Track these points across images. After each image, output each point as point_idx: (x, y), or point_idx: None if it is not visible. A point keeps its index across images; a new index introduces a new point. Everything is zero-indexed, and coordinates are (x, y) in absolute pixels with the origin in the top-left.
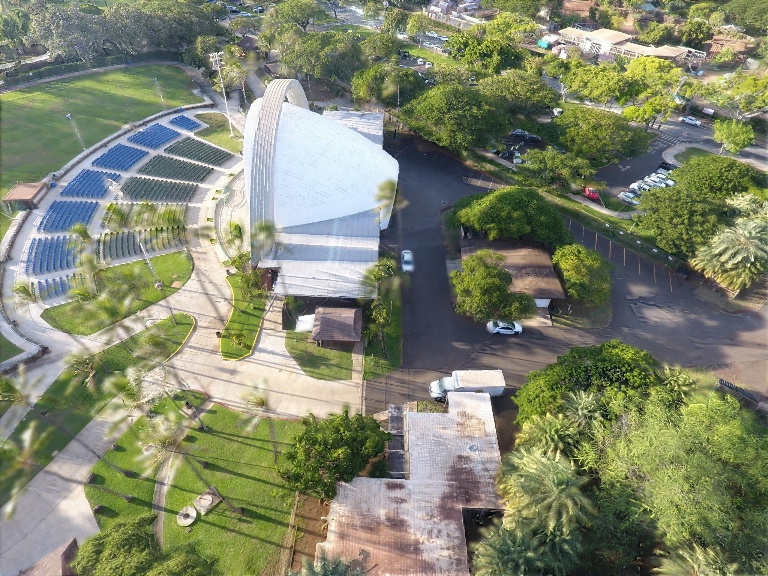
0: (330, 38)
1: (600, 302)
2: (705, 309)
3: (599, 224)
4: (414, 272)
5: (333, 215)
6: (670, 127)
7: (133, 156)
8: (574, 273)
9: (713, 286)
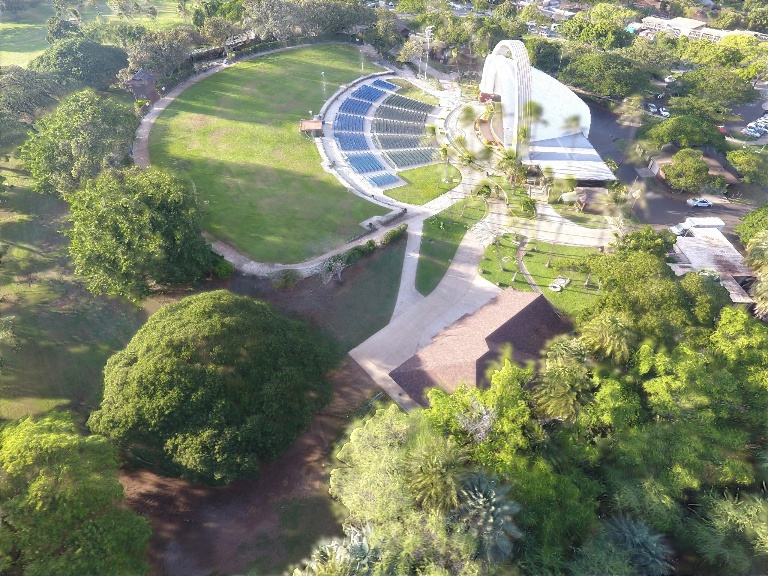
0: (481, 21)
1: (765, 185)
2: None
3: (736, 147)
4: (617, 175)
5: (555, 135)
6: (760, 89)
7: (363, 106)
8: (746, 166)
9: None
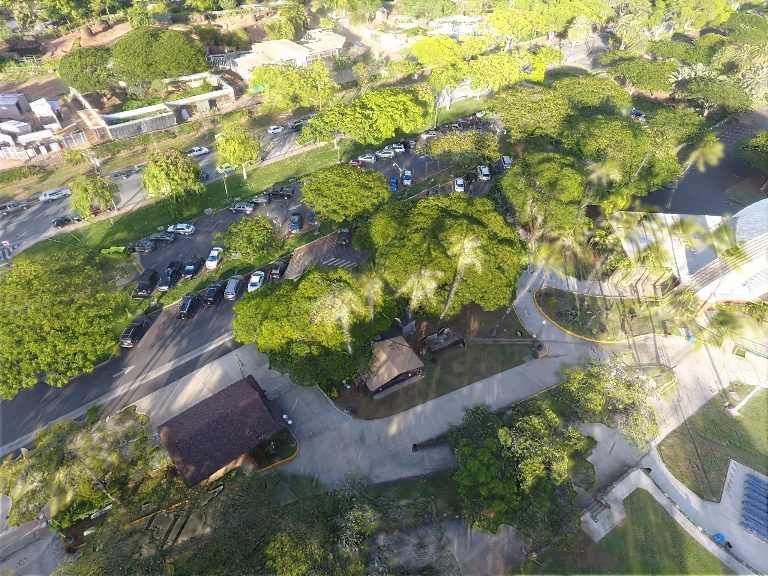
0: (449, 214)
1: None
2: (761, 125)
3: None
4: None
5: None
6: None
7: None
8: None
9: (737, 116)
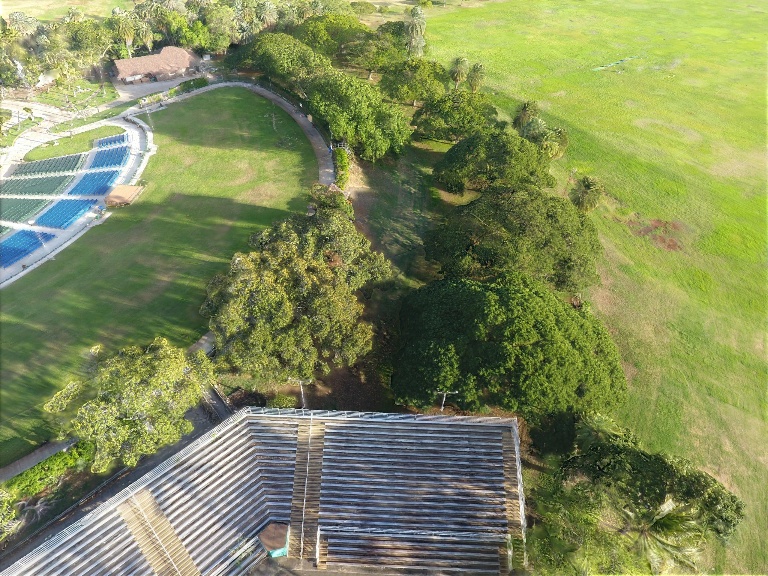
0: None
1: None
2: None
3: None
4: None
5: None
6: None
7: (2, 248)
8: None
9: None
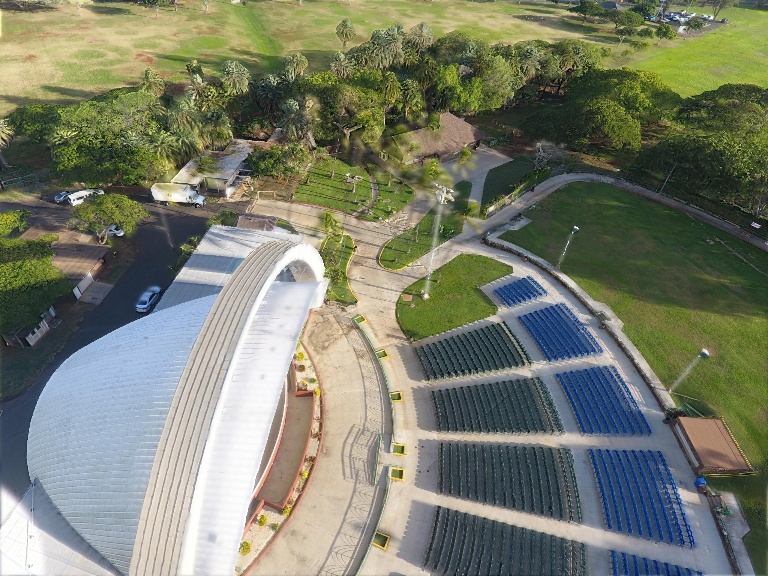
0: None
1: None
2: None
3: None
4: None
5: None
6: None
7: None
8: None
9: None
